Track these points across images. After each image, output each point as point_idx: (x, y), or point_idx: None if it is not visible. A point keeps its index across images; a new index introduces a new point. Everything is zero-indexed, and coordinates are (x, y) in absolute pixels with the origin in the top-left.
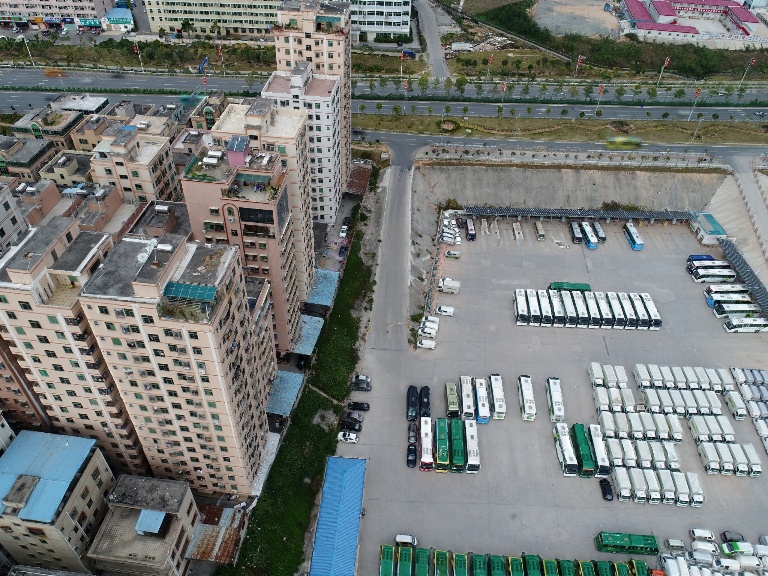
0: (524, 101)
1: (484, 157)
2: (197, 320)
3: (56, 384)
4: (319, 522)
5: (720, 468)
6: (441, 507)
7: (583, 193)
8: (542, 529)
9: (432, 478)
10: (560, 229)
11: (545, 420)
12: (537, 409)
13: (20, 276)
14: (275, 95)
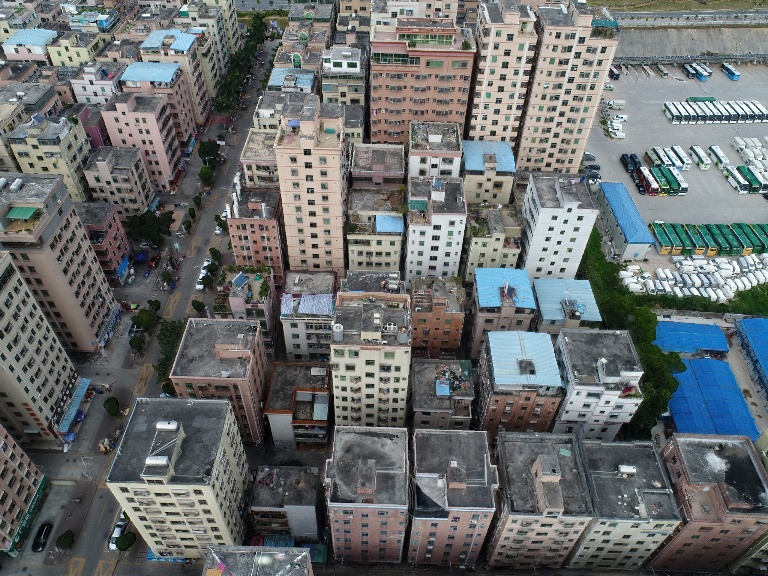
0: None
1: None
2: (611, 37)
3: (491, 105)
4: (613, 210)
5: None
6: (671, 211)
7: (685, 46)
8: (737, 217)
9: (658, 199)
10: (675, 71)
11: (715, 169)
12: None
13: (513, 17)
14: None
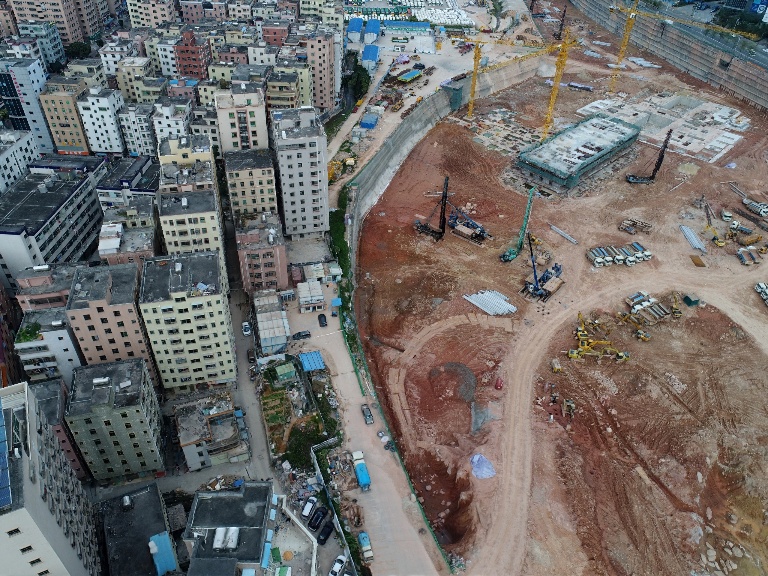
0: None
1: None
2: None
3: None
4: None
5: (432, 3)
6: None
7: None
8: None
9: None
10: None
11: (385, 1)
12: (383, 0)
13: None
14: None
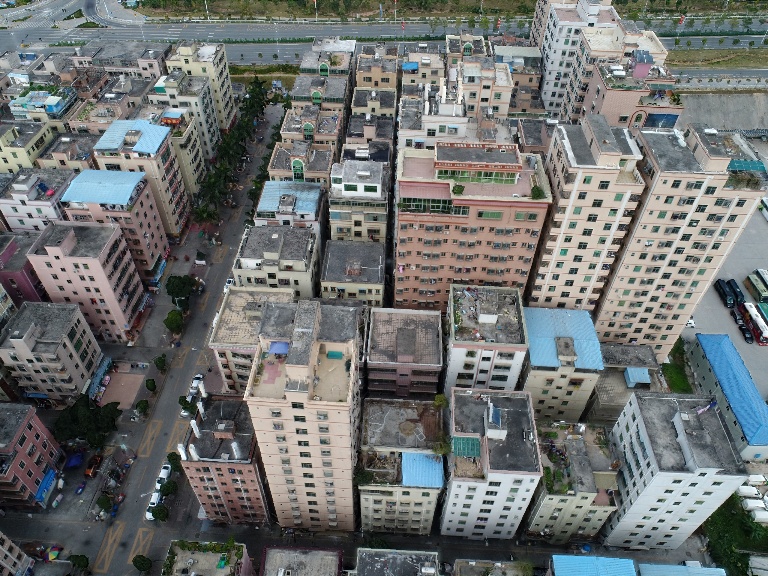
0: (687, 34)
1: (681, 85)
2: (756, 188)
3: (566, 263)
4: (720, 383)
5: None
6: None
7: None
8: None
9: None
10: (764, 147)
11: None
12: None
13: (610, 158)
14: (571, 24)
